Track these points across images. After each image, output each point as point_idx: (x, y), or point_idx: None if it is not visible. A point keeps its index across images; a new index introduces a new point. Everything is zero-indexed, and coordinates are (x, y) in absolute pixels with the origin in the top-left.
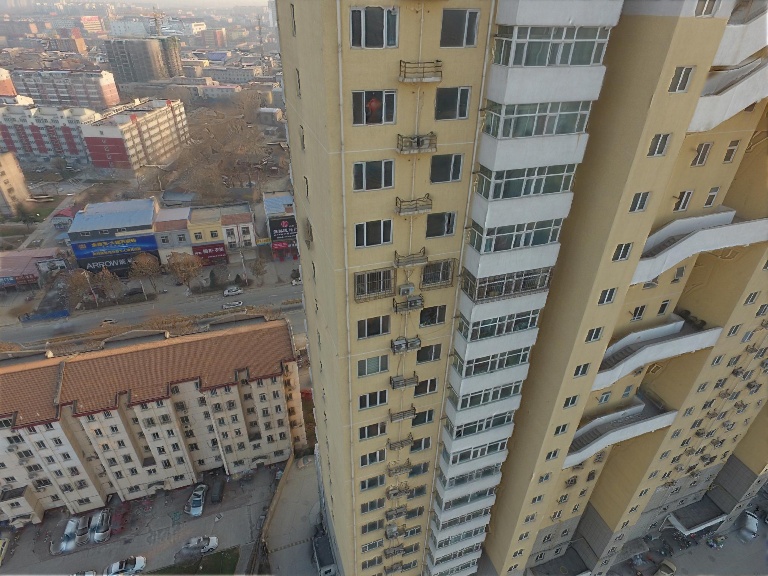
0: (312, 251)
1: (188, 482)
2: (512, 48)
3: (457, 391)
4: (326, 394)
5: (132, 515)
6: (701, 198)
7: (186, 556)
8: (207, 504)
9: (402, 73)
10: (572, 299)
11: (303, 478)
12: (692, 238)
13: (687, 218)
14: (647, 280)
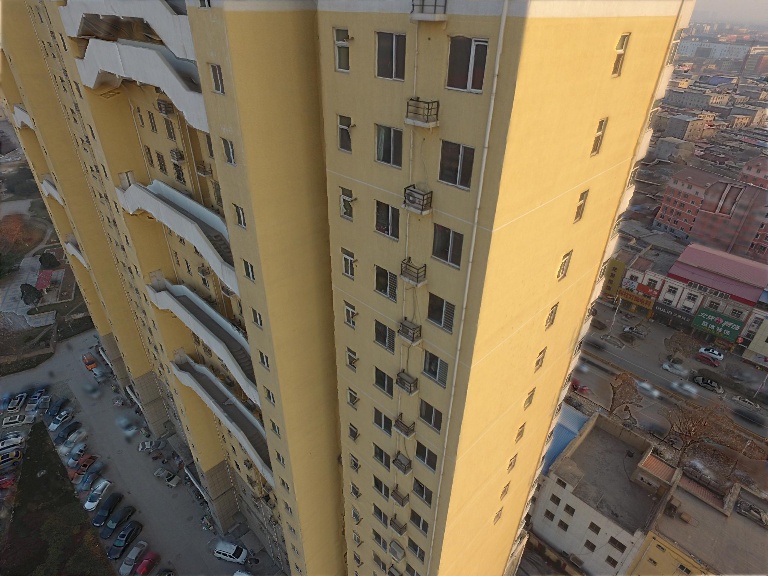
0: None
1: None
2: None
3: None
4: None
5: None
6: None
7: None
8: None
9: None
10: None
11: None
12: (15, 109)
13: None
14: (20, 128)
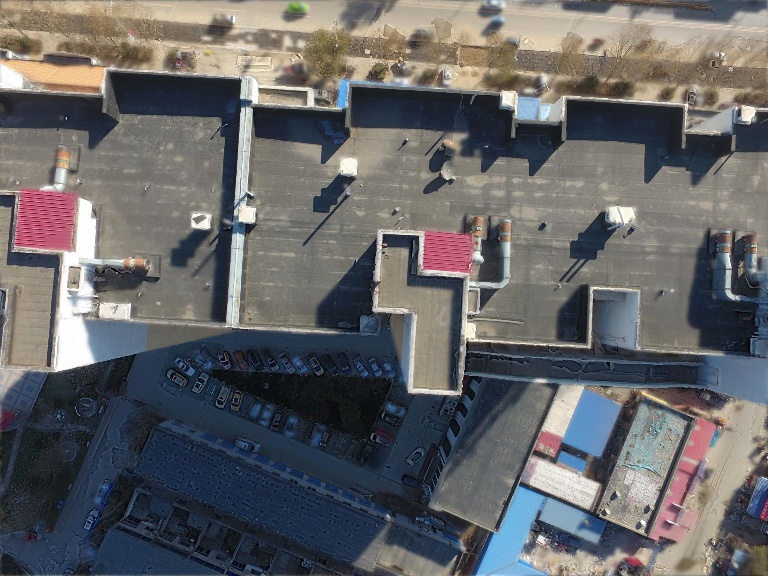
0: None
1: None
2: None
3: None
4: None
5: None
6: None
7: None
8: None
9: None
10: None
11: None
12: None
13: None
14: None
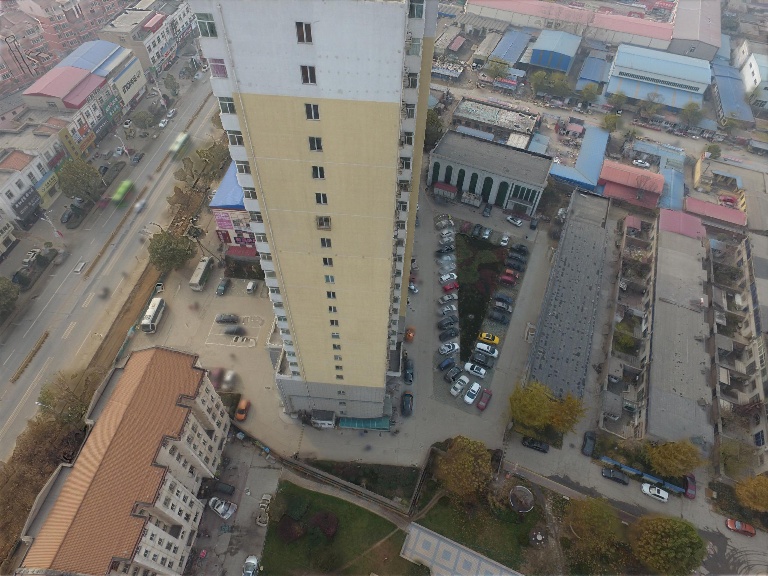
0: (334, 229)
1: (201, 512)
2: (417, 81)
3: (404, 237)
4: (346, 302)
5: (199, 571)
6: None
7: (278, 510)
8: (229, 500)
9: (403, 116)
10: (412, 164)
11: (253, 419)
12: None
13: None
14: None
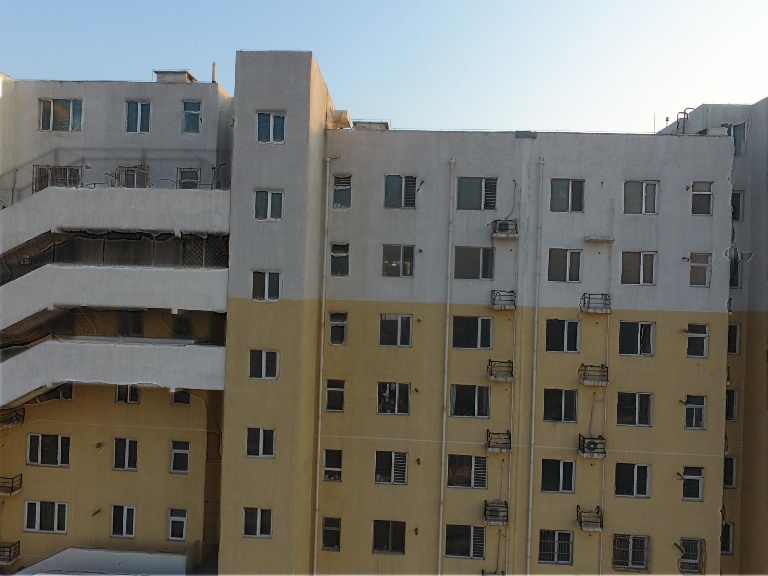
0: None
1: None
2: None
3: None
4: None
5: None
6: (155, 522)
7: None
8: None
9: None
10: None
11: None
12: None
13: (93, 549)
14: None
